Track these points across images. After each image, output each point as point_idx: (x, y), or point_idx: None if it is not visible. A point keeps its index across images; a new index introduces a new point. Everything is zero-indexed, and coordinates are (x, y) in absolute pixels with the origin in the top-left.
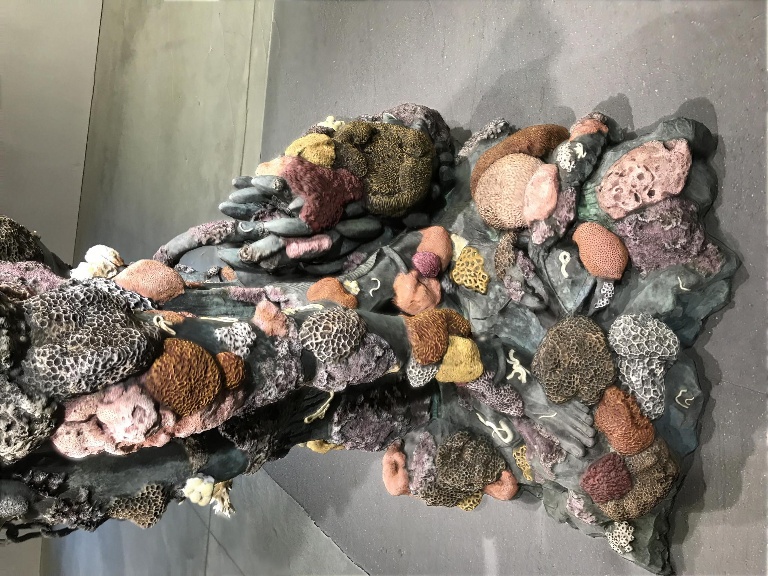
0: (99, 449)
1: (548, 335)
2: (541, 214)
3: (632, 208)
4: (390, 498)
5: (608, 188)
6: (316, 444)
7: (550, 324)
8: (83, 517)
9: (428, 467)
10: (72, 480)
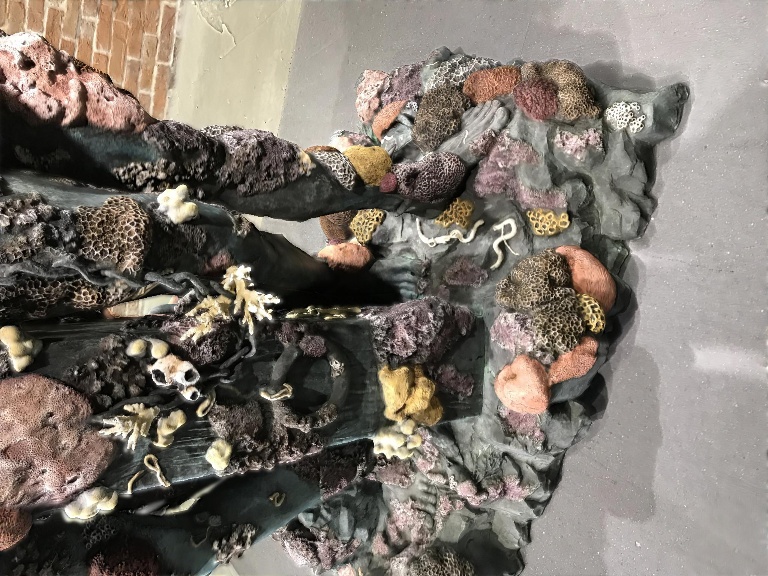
0: (5, 61)
1: (411, 135)
2: (347, 146)
3: (376, 92)
4: (664, 575)
5: (360, 108)
6: (385, 377)
7: (420, 154)
8: (42, 207)
9: (512, 318)
10: (14, 187)
